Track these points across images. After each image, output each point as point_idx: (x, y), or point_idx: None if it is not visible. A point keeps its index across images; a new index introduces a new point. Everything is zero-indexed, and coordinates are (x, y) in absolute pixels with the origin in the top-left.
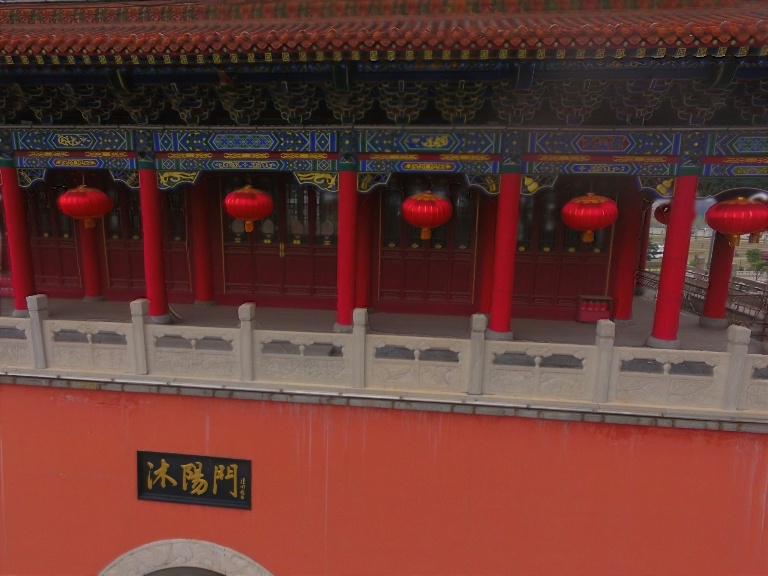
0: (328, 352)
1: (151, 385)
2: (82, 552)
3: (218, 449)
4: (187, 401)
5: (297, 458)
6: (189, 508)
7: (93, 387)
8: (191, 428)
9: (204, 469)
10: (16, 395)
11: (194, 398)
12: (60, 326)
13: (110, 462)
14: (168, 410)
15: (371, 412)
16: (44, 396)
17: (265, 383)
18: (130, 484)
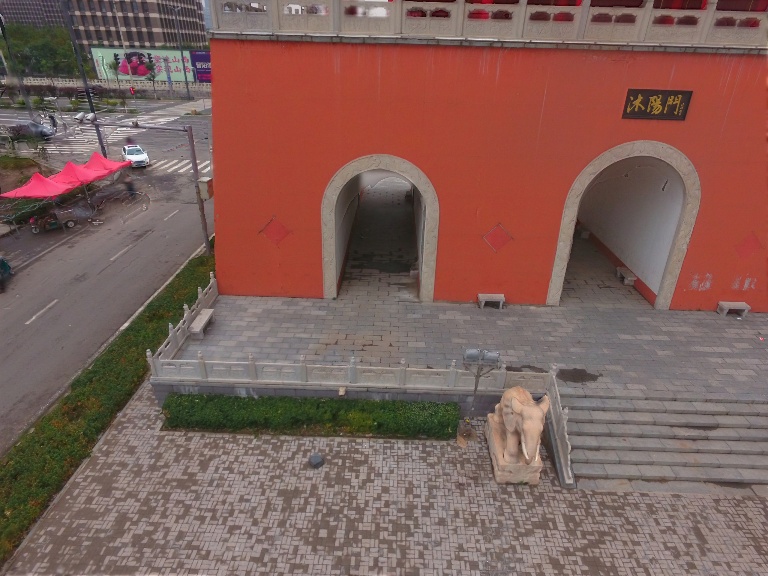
0: (751, 24)
1: (649, 46)
2: (578, 153)
3: (675, 85)
4: (666, 56)
5: (719, 88)
6: (650, 122)
7: (615, 49)
8: (663, 73)
9: (662, 99)
10: (563, 57)
11: (671, 54)
12: (599, 11)
13: (610, 97)
14: (655, 62)
15: (767, 59)
16: (579, 57)
17: (714, 43)
18: (618, 110)
